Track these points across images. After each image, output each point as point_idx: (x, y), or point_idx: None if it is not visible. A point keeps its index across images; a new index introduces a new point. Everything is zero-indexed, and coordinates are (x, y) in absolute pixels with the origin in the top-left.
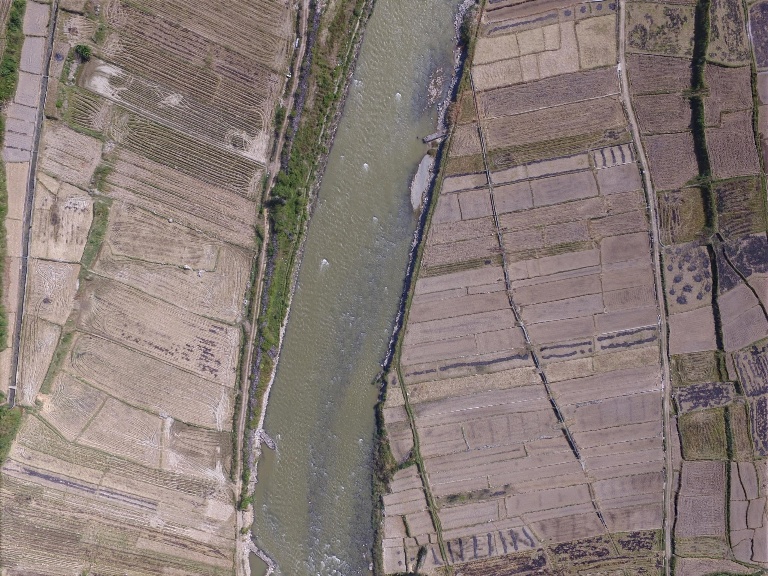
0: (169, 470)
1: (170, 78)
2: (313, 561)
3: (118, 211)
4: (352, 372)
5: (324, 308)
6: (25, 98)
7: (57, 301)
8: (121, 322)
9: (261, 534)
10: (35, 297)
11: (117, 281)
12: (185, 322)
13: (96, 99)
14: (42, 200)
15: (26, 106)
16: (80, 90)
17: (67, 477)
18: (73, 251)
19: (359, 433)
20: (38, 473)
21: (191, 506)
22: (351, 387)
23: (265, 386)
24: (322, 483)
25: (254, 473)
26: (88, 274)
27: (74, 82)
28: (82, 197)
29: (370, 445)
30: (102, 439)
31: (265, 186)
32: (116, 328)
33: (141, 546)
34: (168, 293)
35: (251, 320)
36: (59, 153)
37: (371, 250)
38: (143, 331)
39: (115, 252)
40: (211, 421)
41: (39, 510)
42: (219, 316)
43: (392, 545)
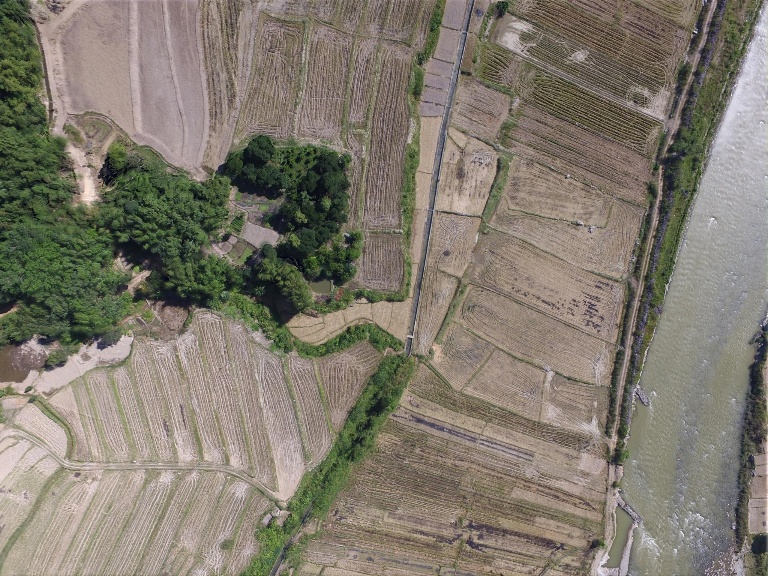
0: (547, 422)
1: (580, 34)
2: (677, 518)
3: (517, 166)
4: (730, 331)
5: (708, 266)
6: (443, 53)
7: (456, 254)
8: (512, 276)
9: (629, 489)
10: (436, 249)
11: (511, 235)
12: (573, 277)
13: (507, 55)
14: (450, 154)
15: (443, 61)
16: (492, 46)
17: (451, 426)
18: (475, 205)
19: (733, 392)
20: (424, 421)
21: (565, 458)
22: (728, 346)
23: (649, 342)
24: (692, 441)
25: None
26: (486, 228)
27: (487, 38)
28: (487, 152)
29: (742, 405)
30: (486, 390)
31: (663, 143)
32: (507, 282)
33: (515, 495)
34: (559, 248)
35: (639, 277)
36: (469, 108)
37: (759, 209)
38: (532, 285)
39: (512, 207)
40: (591, 376)
41: (422, 457)
42: (606, 272)
43: (758, 505)
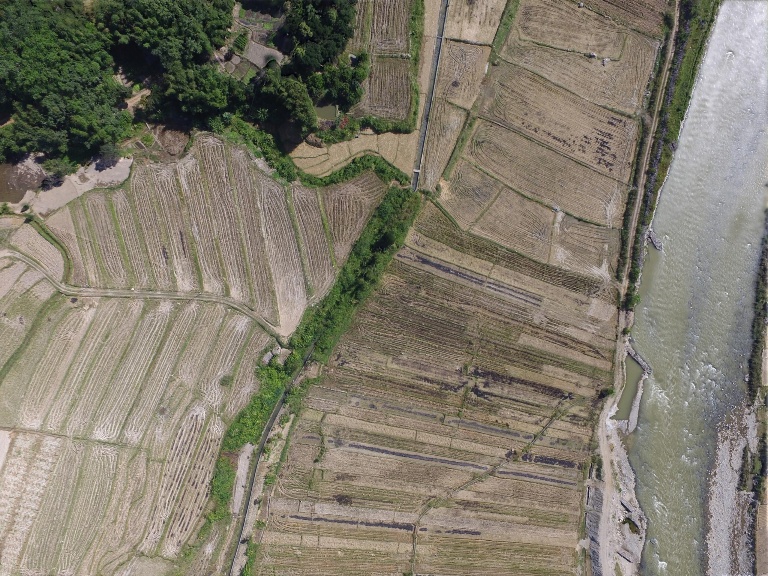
0: (556, 266)
1: None
2: (688, 369)
3: None
4: (746, 173)
5: (725, 103)
6: None
7: (465, 85)
8: (522, 110)
9: (640, 337)
10: (444, 80)
11: (522, 67)
12: (585, 113)
13: None
14: None
15: None
16: None
17: (457, 267)
18: (485, 33)
19: (748, 237)
20: (430, 262)
21: (574, 304)
22: (744, 189)
23: (662, 181)
24: (705, 288)
25: (639, 273)
26: (496, 58)
27: None
28: None
29: (758, 250)
30: (494, 230)
31: None
32: (517, 116)
33: (523, 342)
34: (571, 82)
35: (653, 112)
36: None
37: None
38: (543, 120)
39: (523, 37)
40: (602, 217)
41: (428, 299)
42: (619, 108)
43: None
